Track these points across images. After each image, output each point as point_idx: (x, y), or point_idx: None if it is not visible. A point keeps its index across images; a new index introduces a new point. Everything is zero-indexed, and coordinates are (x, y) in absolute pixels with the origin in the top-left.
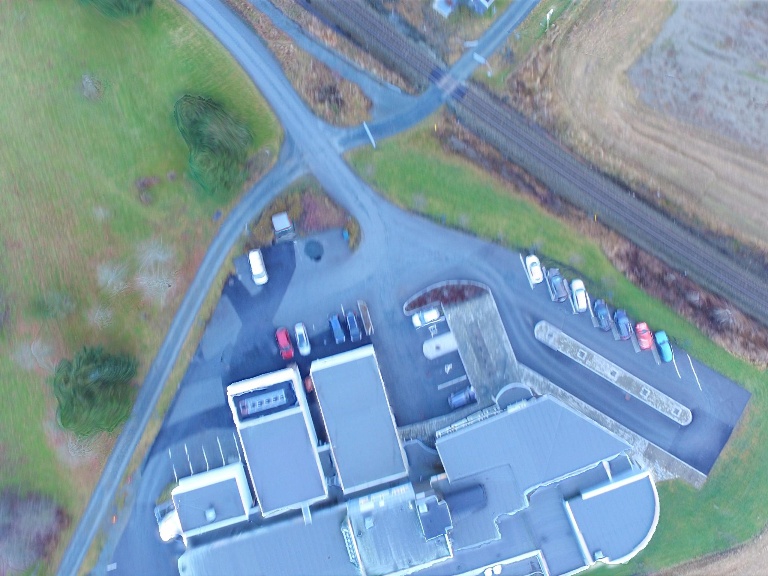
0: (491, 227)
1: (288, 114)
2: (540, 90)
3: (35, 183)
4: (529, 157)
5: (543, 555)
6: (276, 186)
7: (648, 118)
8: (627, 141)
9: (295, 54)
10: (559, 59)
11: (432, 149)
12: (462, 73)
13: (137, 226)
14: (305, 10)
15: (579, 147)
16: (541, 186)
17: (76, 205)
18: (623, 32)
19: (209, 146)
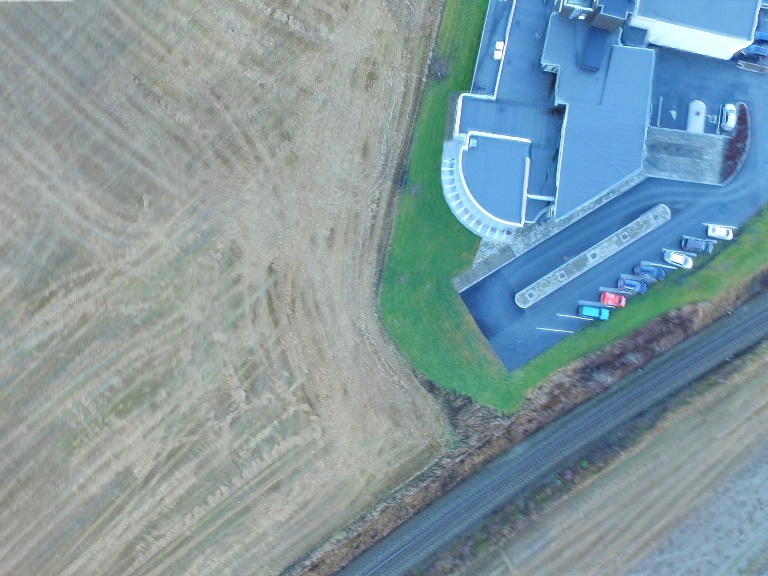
0: None
1: None
2: None
3: None
4: None
5: (491, 100)
6: None
7: None
8: None
9: None
10: None
11: None
12: None
13: None
14: None
15: None
16: None
17: None
18: None
19: None
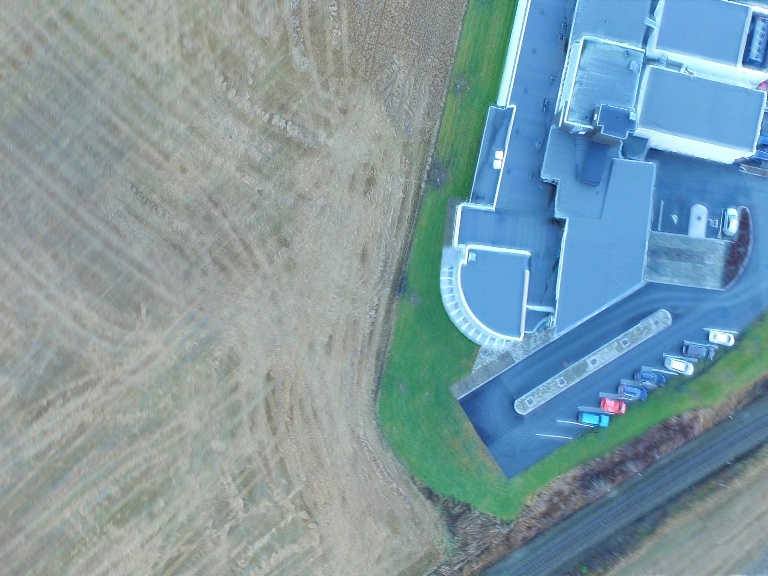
0: None
1: None
2: None
3: None
4: None
5: (490, 210)
6: None
7: None
8: None
9: None
10: None
11: None
12: None
13: None
14: None
15: None
16: None
17: None
18: None
19: None
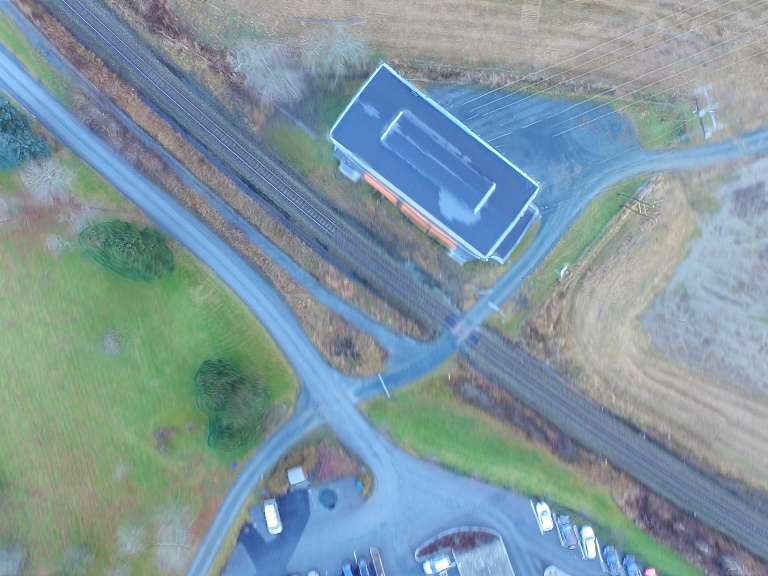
0: (503, 476)
1: (305, 366)
2: (553, 336)
3: (57, 433)
4: (541, 401)
5: None
6: (292, 436)
7: (660, 363)
8: (639, 386)
9: (312, 308)
10: (572, 304)
11: (446, 399)
12: (476, 319)
13: (155, 475)
14: (323, 258)
15: (591, 391)
16: (553, 430)
17: (96, 454)
18: (636, 277)
19: (228, 431)
